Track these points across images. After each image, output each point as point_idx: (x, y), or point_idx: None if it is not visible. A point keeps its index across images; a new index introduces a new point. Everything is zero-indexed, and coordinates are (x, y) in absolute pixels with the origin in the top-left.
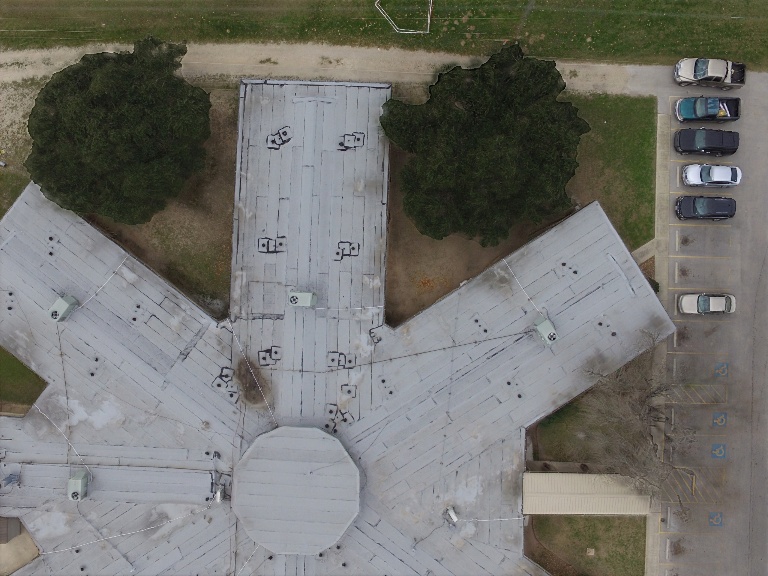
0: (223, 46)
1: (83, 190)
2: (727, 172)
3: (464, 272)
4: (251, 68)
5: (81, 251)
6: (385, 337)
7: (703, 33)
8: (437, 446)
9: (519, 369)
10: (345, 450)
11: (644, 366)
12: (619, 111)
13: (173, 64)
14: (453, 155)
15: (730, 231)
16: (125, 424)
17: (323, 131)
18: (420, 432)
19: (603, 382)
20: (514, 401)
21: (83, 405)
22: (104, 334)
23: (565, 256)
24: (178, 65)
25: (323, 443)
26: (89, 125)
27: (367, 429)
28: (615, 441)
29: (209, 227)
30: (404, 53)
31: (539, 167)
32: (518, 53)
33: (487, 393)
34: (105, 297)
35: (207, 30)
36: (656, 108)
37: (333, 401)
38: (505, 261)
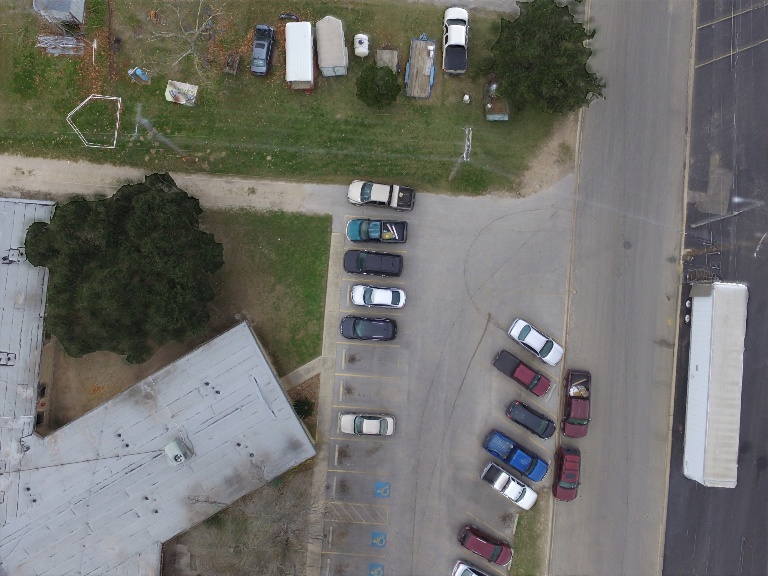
0: None
1: None
2: (388, 295)
3: (133, 381)
4: None
5: None
6: (34, 446)
7: (381, 154)
8: (76, 556)
9: (158, 485)
10: None
11: (305, 482)
12: (293, 229)
13: None
14: (68, 284)
15: (399, 351)
16: None
17: None
18: (61, 541)
19: (239, 502)
20: (152, 516)
21: None
22: None
23: (210, 376)
24: None
25: None
26: None
27: (9, 535)
28: (209, 572)
29: None
30: (91, 166)
31: (154, 297)
32: (161, 180)
33: (127, 507)
34: None
35: None
36: (331, 227)
37: None
38: (151, 378)
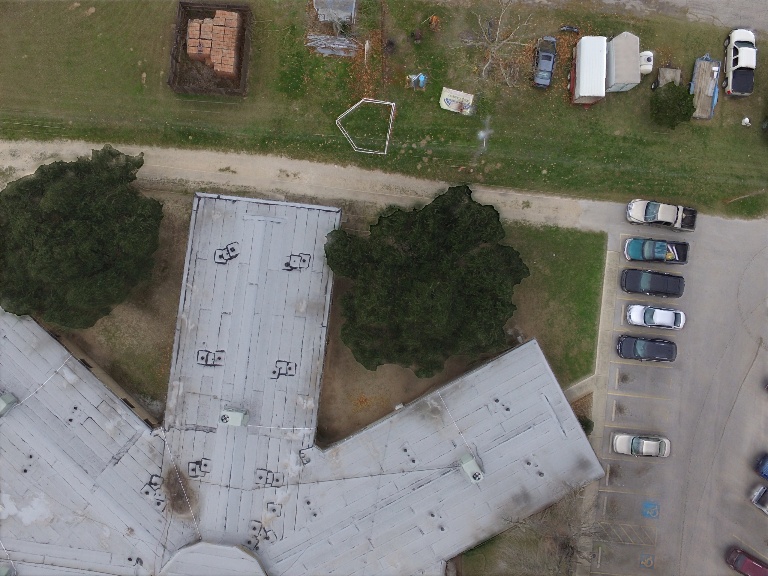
0: (184, 151)
1: (28, 296)
2: (670, 316)
3: (402, 394)
4: (210, 175)
5: (26, 348)
6: (314, 459)
7: (659, 173)
8: (357, 572)
9: (444, 502)
10: (263, 572)
11: None
12: (569, 245)
13: (128, 177)
14: (388, 297)
15: (671, 373)
16: (53, 522)
17: (270, 250)
18: (341, 557)
19: (527, 522)
20: (437, 533)
21: (14, 500)
22: (40, 432)
23: (499, 392)
24: (133, 177)
25: (242, 563)
26: (36, 240)
27: (288, 550)
28: None
29: (155, 328)
30: (360, 172)
31: (473, 313)
32: (465, 192)
33: (411, 523)
34: (45, 395)
35: (170, 135)
36: (606, 244)
37: (258, 518)
38: (439, 393)
